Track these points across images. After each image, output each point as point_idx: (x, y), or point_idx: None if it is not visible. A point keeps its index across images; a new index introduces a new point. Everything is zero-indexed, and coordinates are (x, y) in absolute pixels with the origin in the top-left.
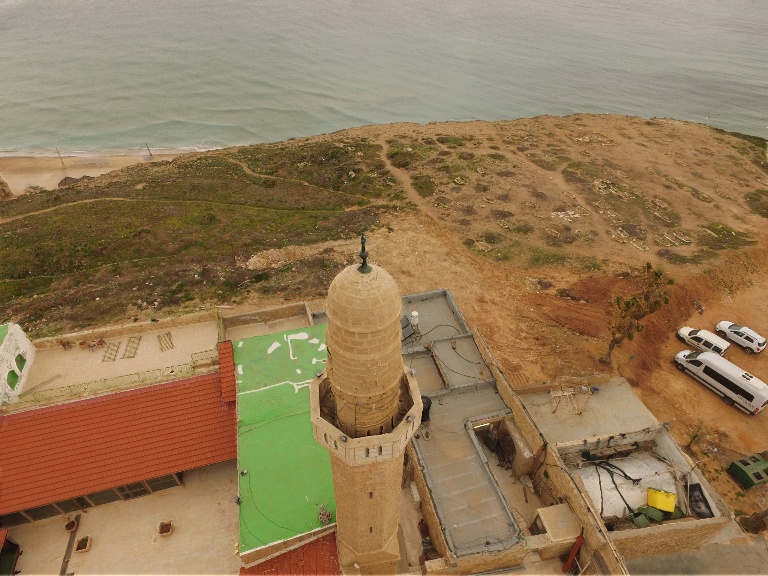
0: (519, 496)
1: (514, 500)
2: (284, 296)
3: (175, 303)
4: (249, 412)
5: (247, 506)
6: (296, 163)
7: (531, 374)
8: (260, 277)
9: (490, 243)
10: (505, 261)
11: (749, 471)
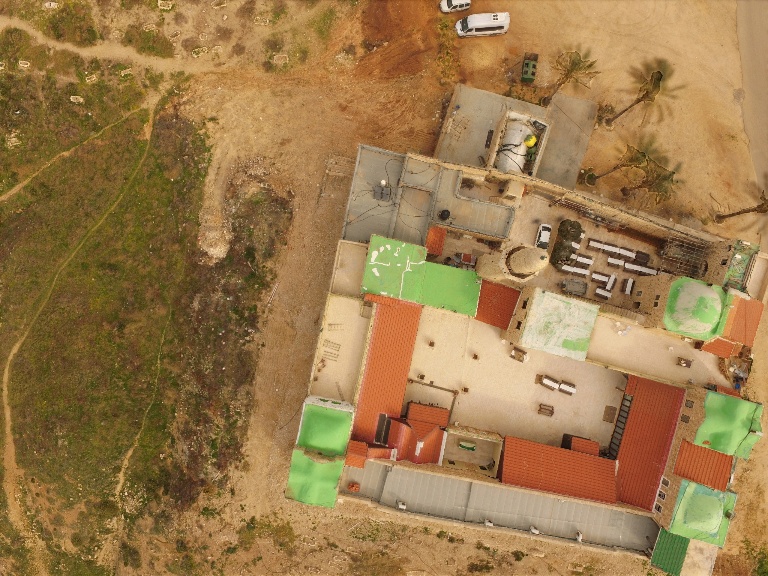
0: (487, 191)
1: (487, 194)
2: (281, 244)
3: (255, 318)
4: (414, 296)
5: (458, 309)
6: (3, 145)
7: (420, 126)
8: (250, 254)
9: (279, 51)
10: (308, 57)
11: (530, 76)
